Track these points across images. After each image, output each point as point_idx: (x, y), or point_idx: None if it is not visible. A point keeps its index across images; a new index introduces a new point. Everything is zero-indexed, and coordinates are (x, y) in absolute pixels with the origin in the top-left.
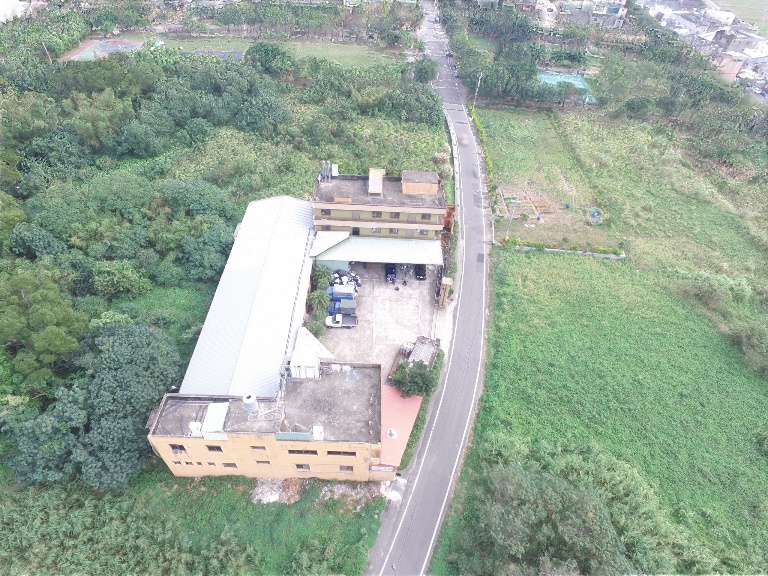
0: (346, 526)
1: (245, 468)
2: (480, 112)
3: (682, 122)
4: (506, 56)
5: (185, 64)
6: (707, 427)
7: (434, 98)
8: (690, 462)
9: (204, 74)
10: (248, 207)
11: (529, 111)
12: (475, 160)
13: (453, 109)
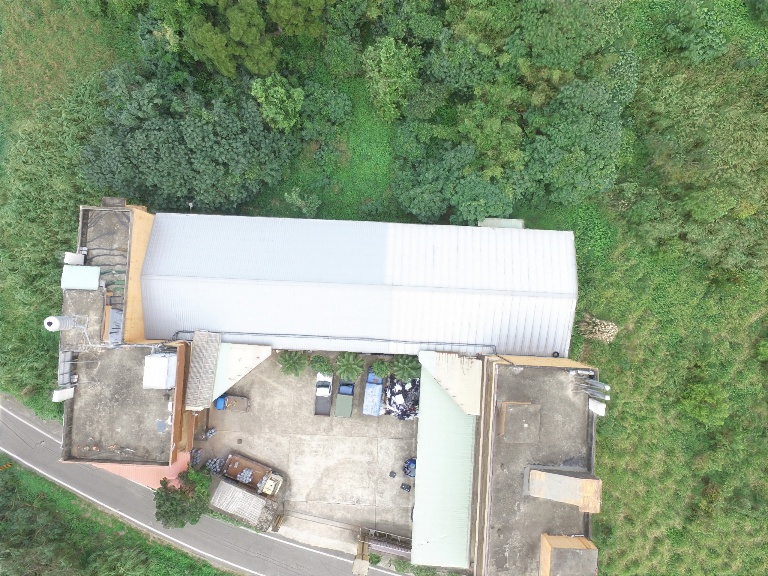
0: None
1: None
2: None
3: None
4: None
5: None
6: None
7: None
8: None
9: None
10: (556, 232)
11: None
12: None
13: None
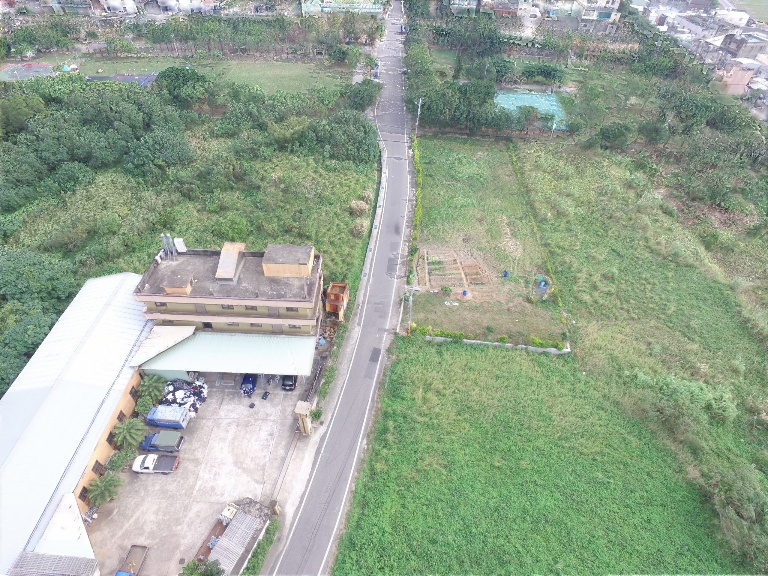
0: None
1: None
2: (425, 143)
3: (669, 152)
4: (467, 73)
5: (75, 95)
6: None
7: (366, 129)
8: None
9: None
10: (82, 287)
11: (485, 141)
12: (402, 209)
13: (392, 140)
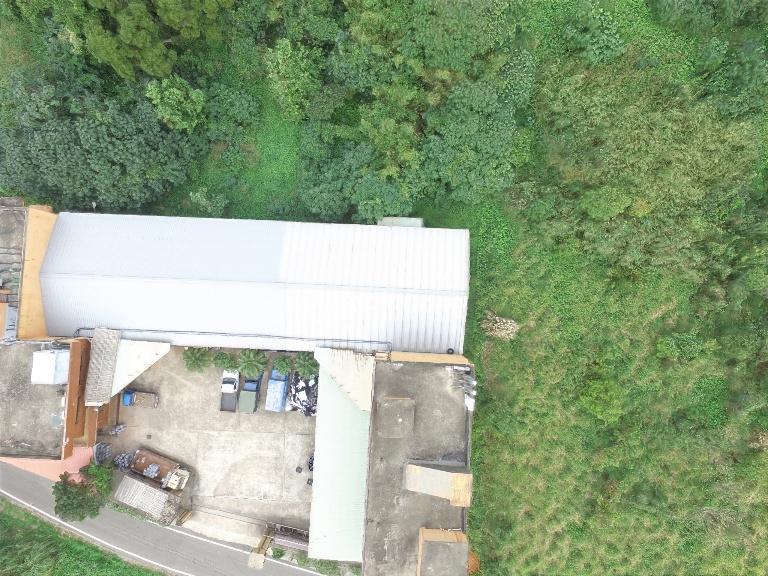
0: None
1: None
2: None
3: None
4: None
5: None
6: None
7: None
8: None
9: None
10: (452, 230)
11: None
12: None
13: None
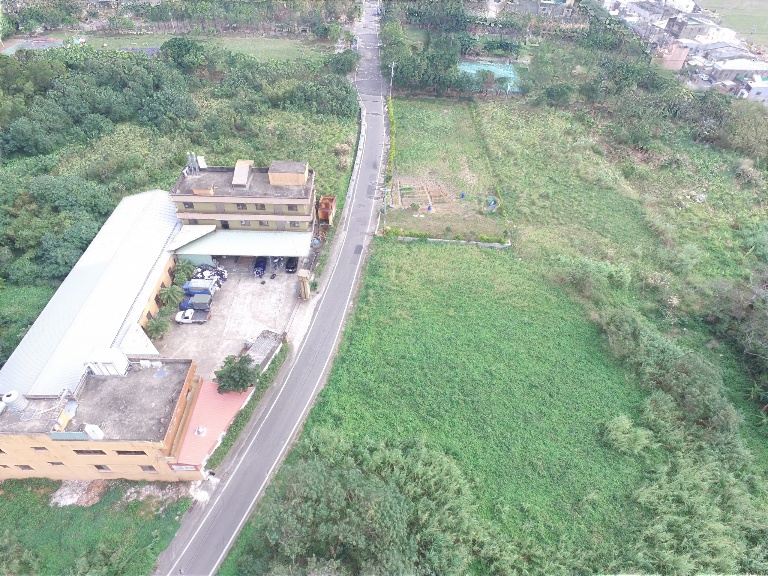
0: (140, 529)
1: (43, 470)
2: (399, 103)
3: (605, 109)
4: (435, 46)
5: (91, 60)
6: (550, 418)
7: (347, 89)
8: (523, 455)
9: (114, 70)
10: (120, 202)
11: (450, 101)
12: (379, 151)
13: (370, 100)
